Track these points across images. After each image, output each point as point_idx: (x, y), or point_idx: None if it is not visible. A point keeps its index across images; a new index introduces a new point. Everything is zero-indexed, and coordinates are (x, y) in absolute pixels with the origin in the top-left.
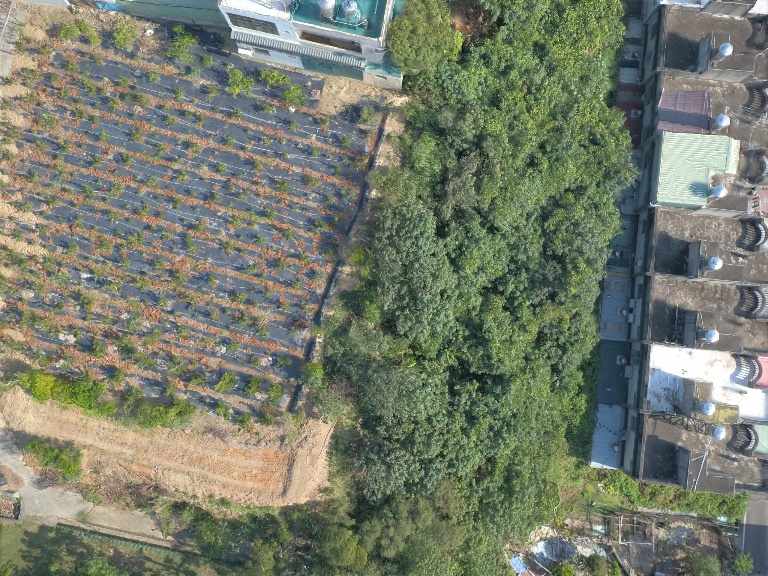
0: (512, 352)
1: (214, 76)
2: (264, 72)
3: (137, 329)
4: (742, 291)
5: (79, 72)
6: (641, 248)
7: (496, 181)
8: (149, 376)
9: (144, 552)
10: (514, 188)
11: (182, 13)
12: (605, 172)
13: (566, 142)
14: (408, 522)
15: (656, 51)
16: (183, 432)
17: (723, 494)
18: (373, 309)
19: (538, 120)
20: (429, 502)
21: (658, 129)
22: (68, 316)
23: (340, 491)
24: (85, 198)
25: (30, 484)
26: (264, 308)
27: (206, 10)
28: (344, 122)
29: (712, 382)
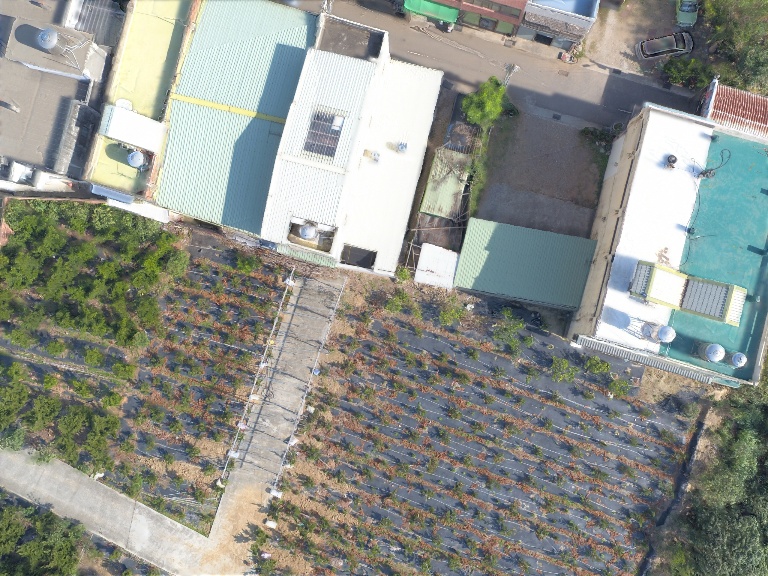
0: None
1: (533, 355)
2: (590, 361)
3: None
4: None
5: (398, 342)
6: None
7: None
8: None
9: None
10: None
11: None
12: None
13: None
14: None
15: None
16: None
17: None
18: None
19: None
20: None
21: None
22: None
23: None
24: (398, 470)
25: None
26: None
27: (543, 303)
28: (662, 411)
29: None
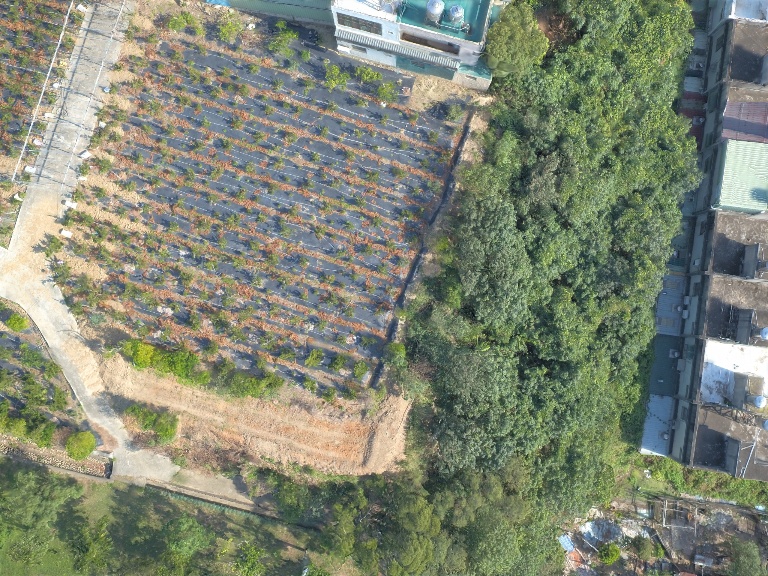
0: (580, 341)
1: (311, 70)
2: (360, 68)
3: (231, 305)
4: None
5: (184, 61)
6: (699, 248)
7: (575, 180)
8: (240, 349)
9: (226, 514)
10: (591, 187)
11: (285, 10)
12: (672, 175)
13: (639, 146)
14: (479, 495)
15: (722, 62)
16: (271, 403)
17: None
18: (456, 295)
19: (613, 124)
20: None
21: (722, 137)
22: (166, 290)
23: (414, 464)
24: (186, 180)
25: (124, 446)
26: (350, 290)
27: (310, 8)
28: (432, 118)
29: (763, 377)
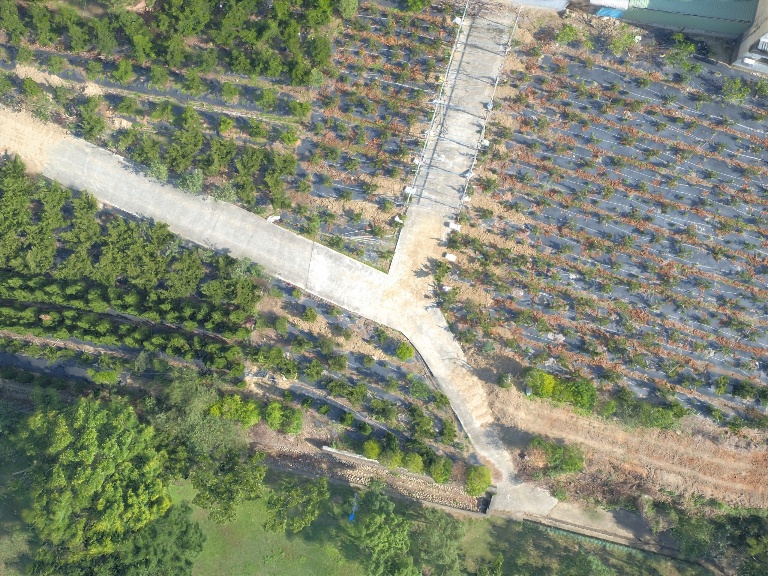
0: None
1: (701, 84)
2: (760, 82)
3: None
4: None
5: (568, 75)
6: None
7: None
8: (635, 377)
9: (607, 549)
10: None
11: (683, 21)
12: None
13: None
14: None
15: None
16: (674, 433)
17: None
18: None
19: None
20: None
21: None
22: (556, 315)
23: None
24: (573, 200)
25: (508, 479)
26: (751, 313)
27: (718, 19)
28: None
29: None
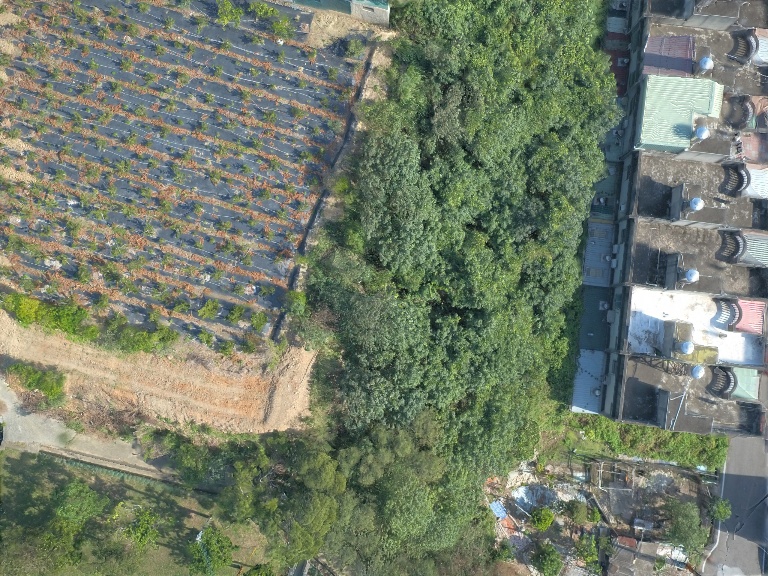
0: (494, 286)
1: (204, 8)
2: (253, 4)
3: (122, 256)
4: (724, 236)
5: (70, 2)
6: (625, 193)
7: (480, 114)
8: (133, 303)
9: (125, 480)
10: (498, 122)
11: None
12: (590, 113)
13: (551, 80)
14: (387, 450)
15: None
16: (166, 358)
17: (701, 434)
18: (356, 237)
19: (524, 59)
20: (409, 433)
21: (643, 74)
22: (54, 242)
23: (321, 421)
24: (73, 126)
25: (13, 409)
26: (249, 237)
27: None
28: (332, 56)
29: (692, 323)
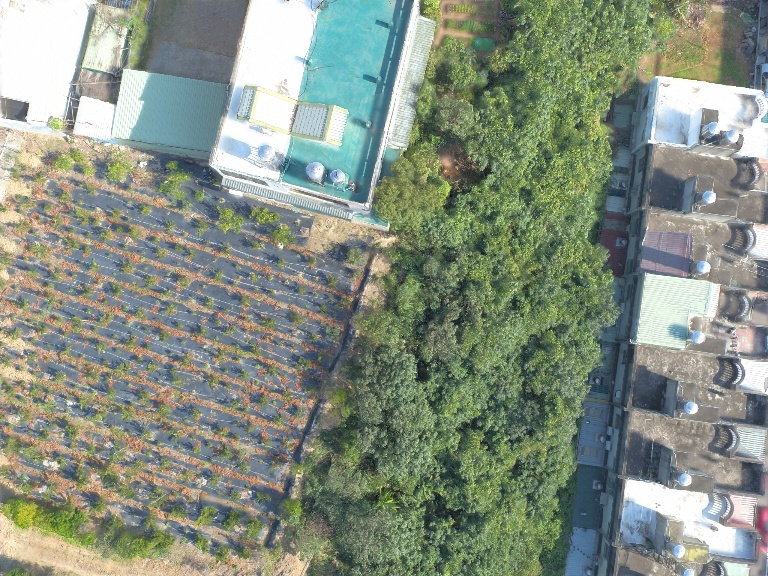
0: (488, 492)
1: (205, 210)
2: (254, 211)
3: (120, 458)
4: (717, 428)
5: (72, 201)
6: (620, 379)
7: (477, 330)
8: (130, 504)
9: None
10: (495, 335)
11: (175, 150)
12: (586, 312)
13: (548, 287)
14: None
15: (642, 188)
16: (162, 562)
17: None
18: (352, 452)
19: (522, 262)
20: None
21: (641, 268)
22: (53, 442)
23: None
24: (74, 326)
25: None
26: (246, 442)
27: (199, 151)
28: (331, 260)
29: (684, 521)
